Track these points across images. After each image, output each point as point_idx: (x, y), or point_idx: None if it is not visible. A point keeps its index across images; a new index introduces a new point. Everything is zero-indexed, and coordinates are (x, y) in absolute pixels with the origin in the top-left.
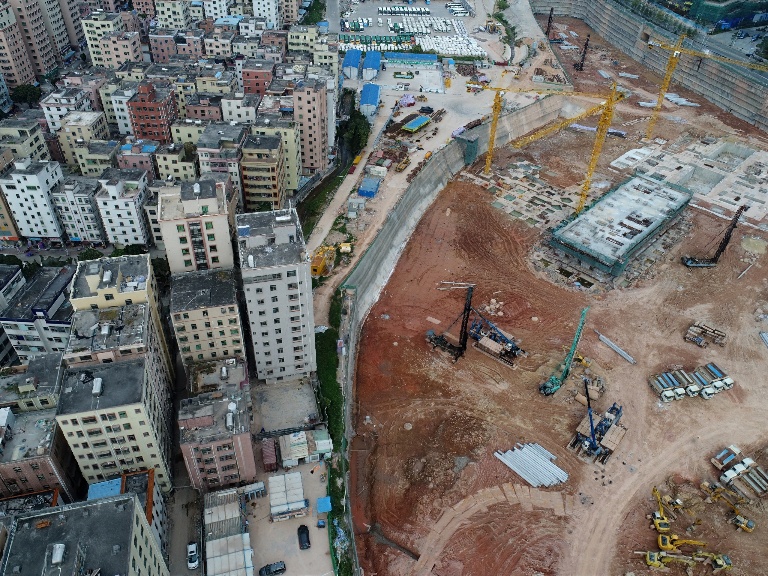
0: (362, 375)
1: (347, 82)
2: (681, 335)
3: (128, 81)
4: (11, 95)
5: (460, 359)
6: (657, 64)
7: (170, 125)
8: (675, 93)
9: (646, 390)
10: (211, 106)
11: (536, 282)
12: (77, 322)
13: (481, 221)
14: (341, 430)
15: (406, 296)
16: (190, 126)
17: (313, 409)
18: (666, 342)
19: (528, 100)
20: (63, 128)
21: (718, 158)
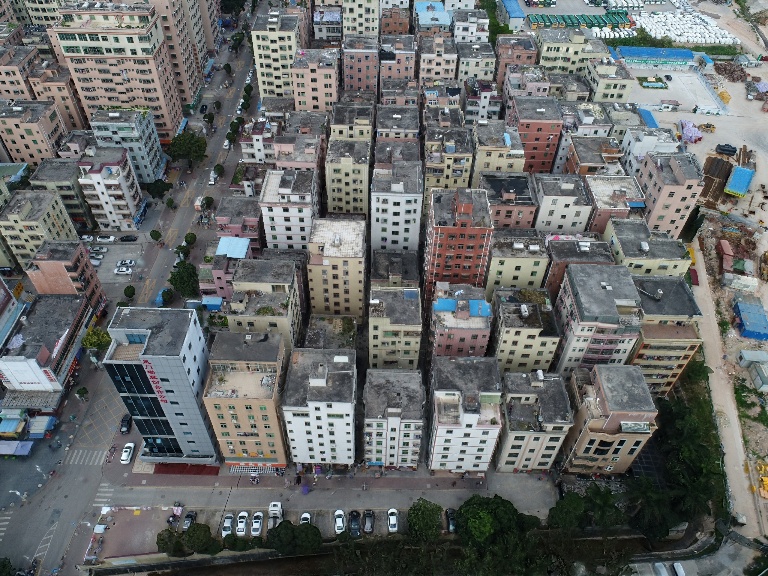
0: None
1: None
2: None
3: (355, 142)
4: (168, 152)
5: None
6: None
7: None
8: None
9: None
10: (525, 205)
11: None
12: None
13: None
14: None
15: None
16: (521, 254)
17: None
18: None
19: None
20: (312, 254)
21: None
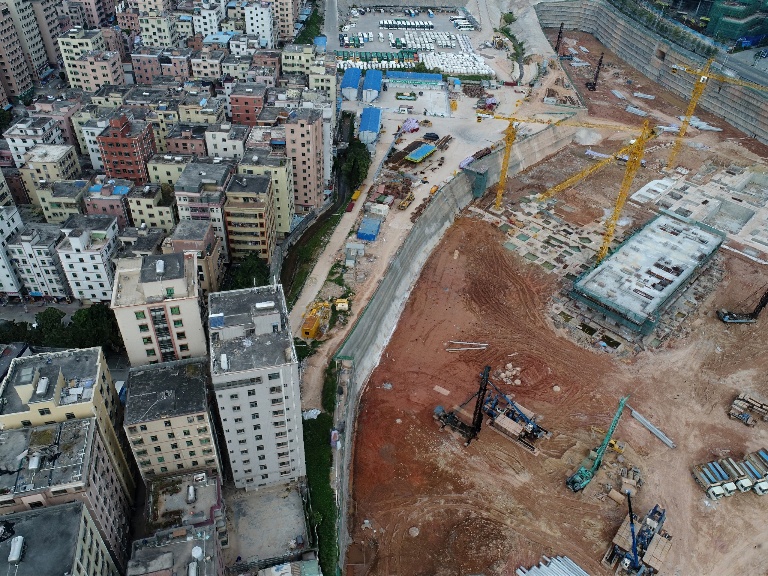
0: (360, 462)
1: (346, 104)
2: (724, 410)
3: (105, 107)
4: None
5: (473, 441)
6: (674, 84)
7: (146, 162)
8: (694, 116)
9: (690, 483)
10: (194, 139)
11: (556, 342)
12: (1, 448)
13: (493, 266)
14: (334, 558)
15: (410, 359)
16: (169, 163)
17: (301, 527)
18: (708, 419)
19: (540, 125)
20: (27, 164)
21: (745, 189)
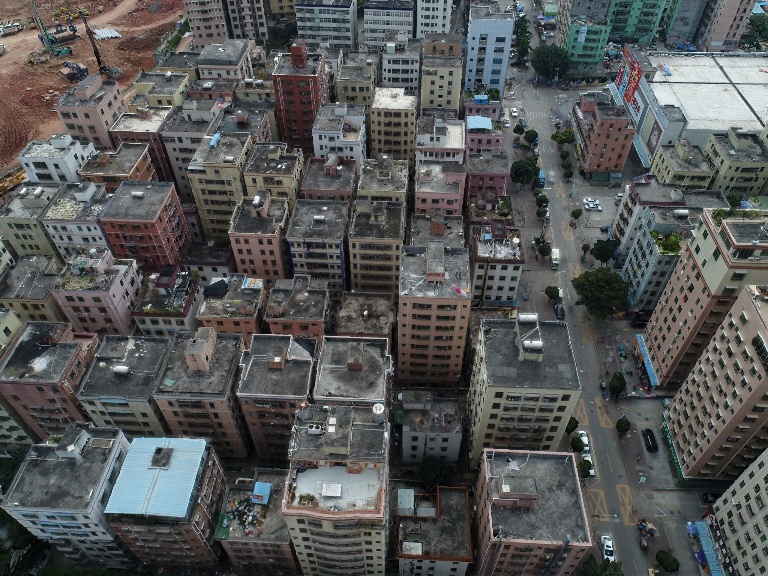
0: None
1: None
2: None
3: None
4: None
5: None
6: None
7: None
8: None
9: None
10: (233, 108)
11: None
12: None
13: None
14: None
15: None
16: None
17: None
18: None
19: None
20: None
21: None
